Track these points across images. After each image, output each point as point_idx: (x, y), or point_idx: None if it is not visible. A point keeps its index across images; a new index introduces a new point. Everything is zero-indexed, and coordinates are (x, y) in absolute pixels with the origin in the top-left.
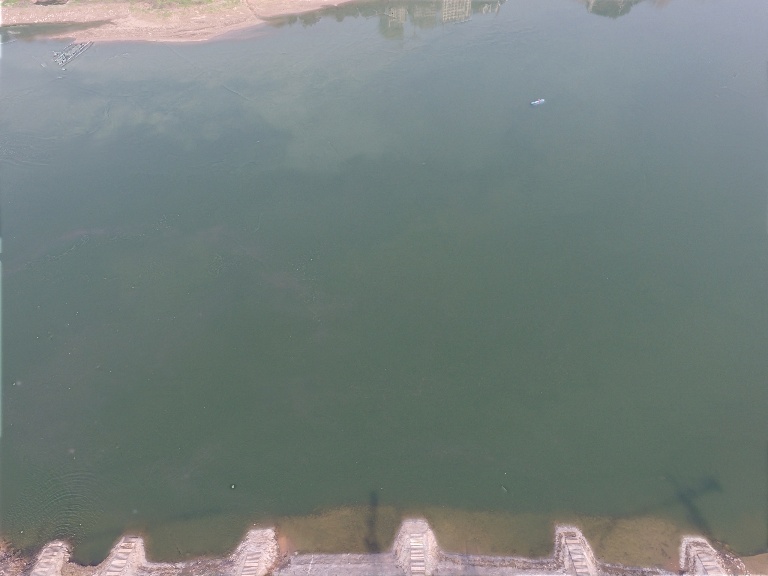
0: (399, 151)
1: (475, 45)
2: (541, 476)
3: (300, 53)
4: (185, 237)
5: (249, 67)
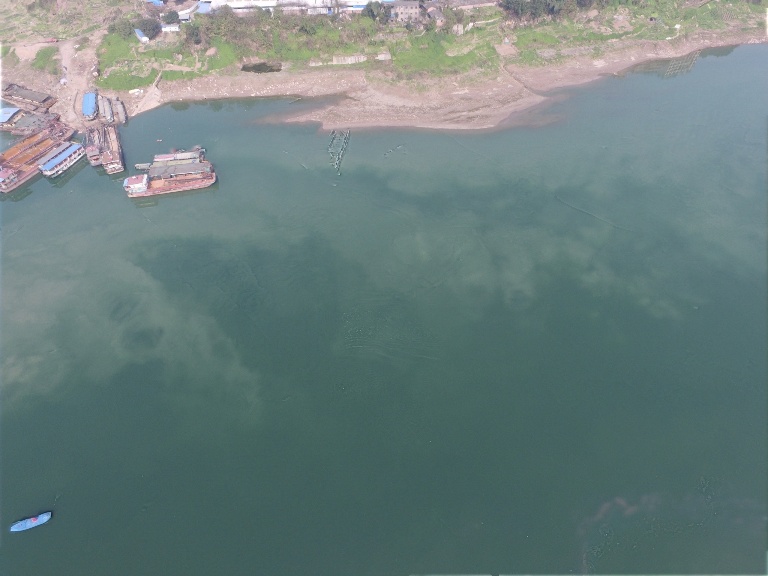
0: None
1: None
2: None
3: (627, 148)
4: (763, 528)
5: (574, 170)
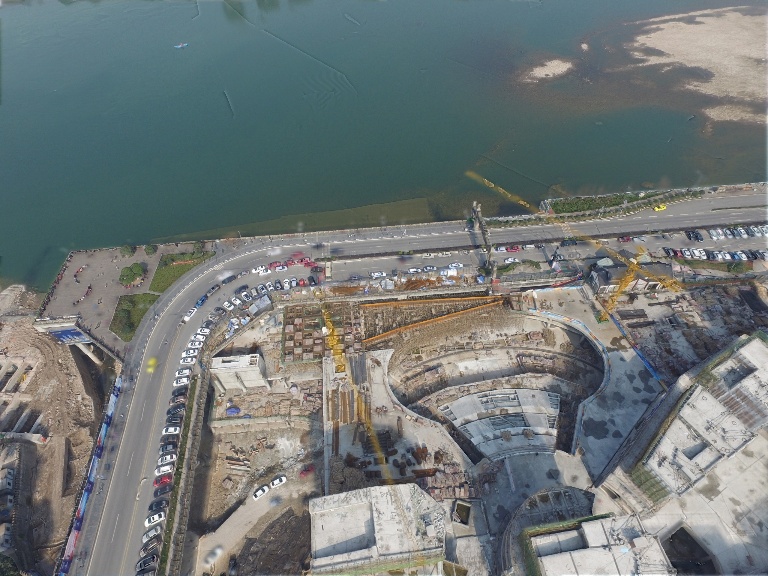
0: (43, 83)
1: (175, 7)
2: None
3: (30, 18)
4: None
5: None
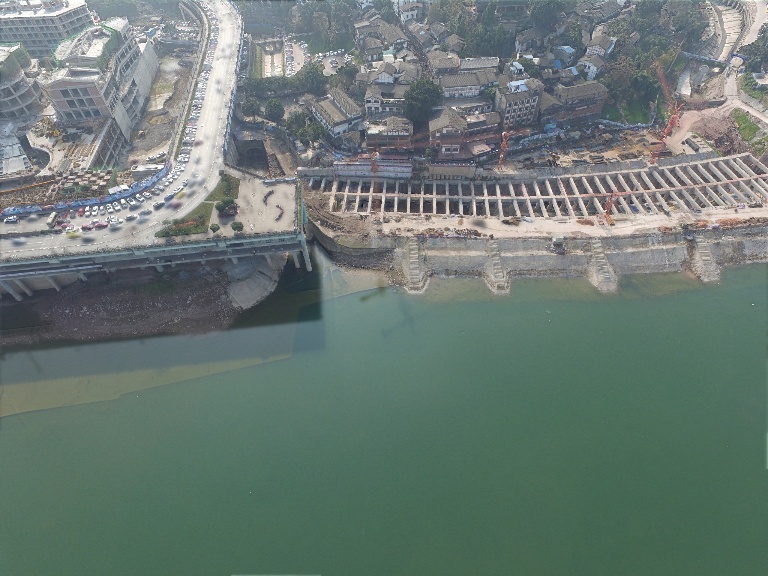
0: None
1: None
2: (521, 321)
3: None
4: None
5: None
